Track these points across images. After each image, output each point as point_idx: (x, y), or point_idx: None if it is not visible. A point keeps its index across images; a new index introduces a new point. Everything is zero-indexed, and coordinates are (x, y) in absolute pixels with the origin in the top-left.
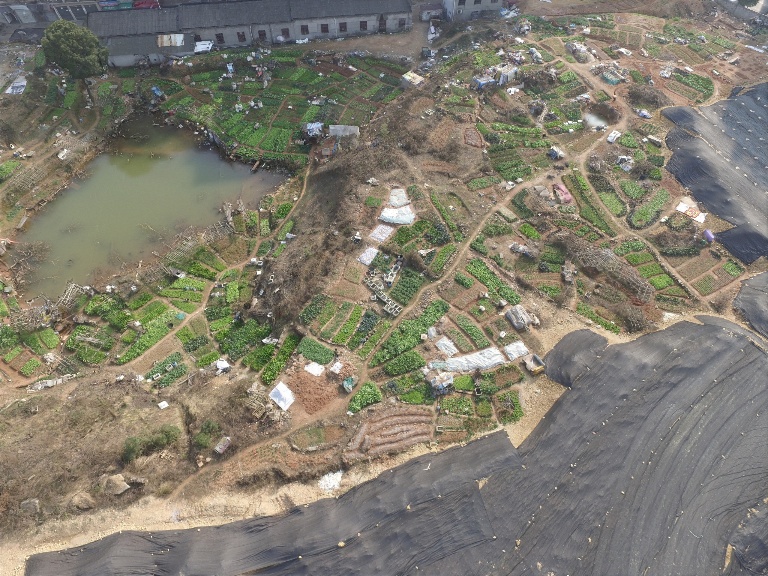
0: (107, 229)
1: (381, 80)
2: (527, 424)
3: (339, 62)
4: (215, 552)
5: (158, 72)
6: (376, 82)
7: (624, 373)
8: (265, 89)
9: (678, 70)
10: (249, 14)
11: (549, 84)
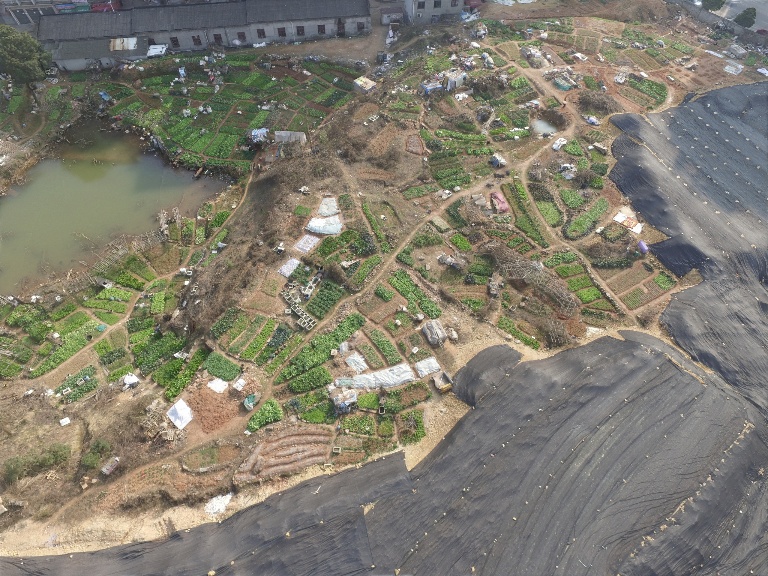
0: (40, 237)
1: (334, 85)
2: (427, 445)
3: (294, 66)
4: None
5: (108, 76)
6: (329, 87)
7: (531, 392)
8: (216, 94)
9: (633, 76)
10: (204, 17)
11: (500, 90)
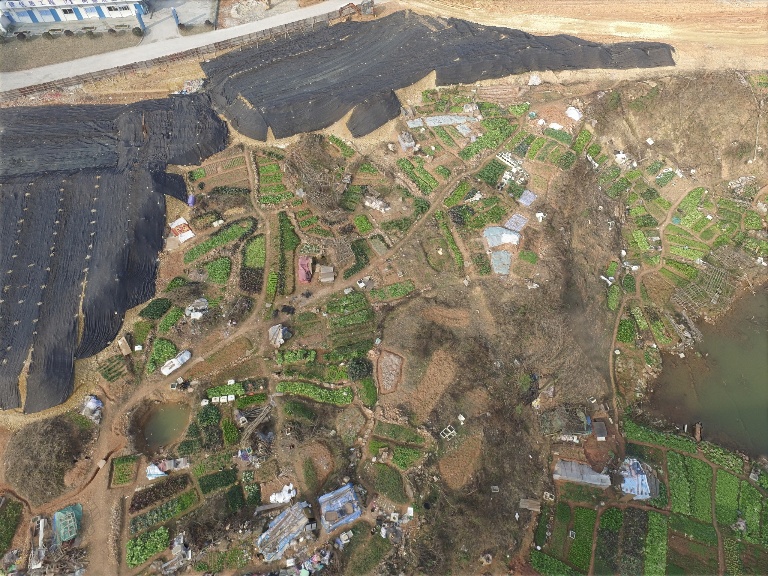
0: None
1: None
2: (422, 85)
3: None
4: (587, 56)
5: None
6: None
7: (354, 92)
8: None
9: None
10: None
11: None
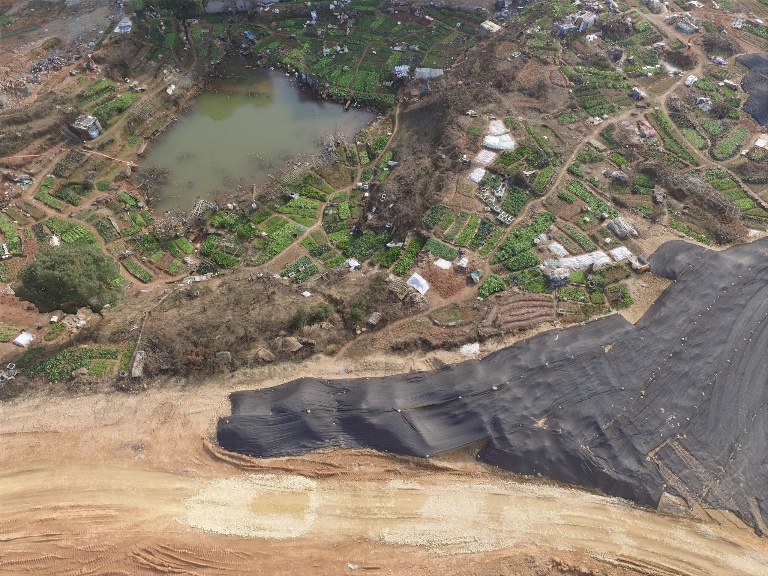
0: (219, 157)
1: (458, 29)
2: (638, 309)
3: (416, 12)
4: (387, 393)
5: (247, 18)
6: (453, 31)
7: (723, 270)
8: (348, 36)
9: (749, 22)
10: None
11: (625, 32)
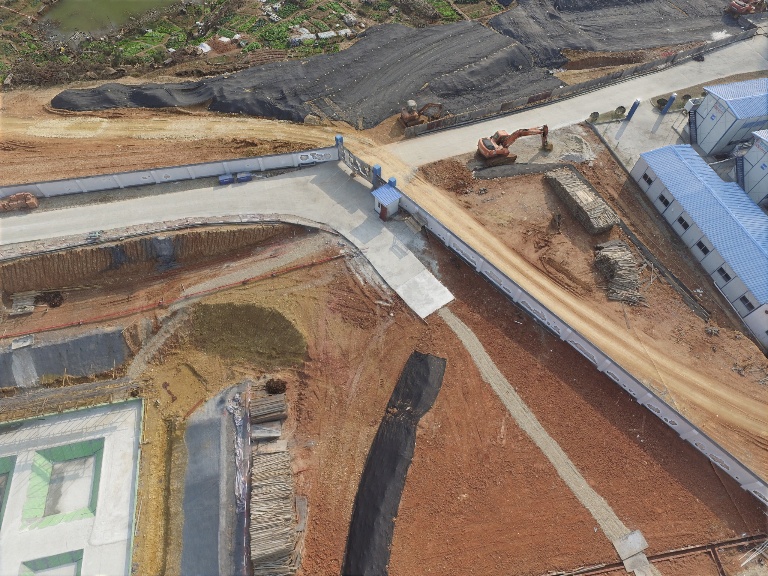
0: (100, 14)
1: None
2: None
3: None
4: None
5: None
6: None
7: (398, 31)
8: None
9: None
10: None
11: None
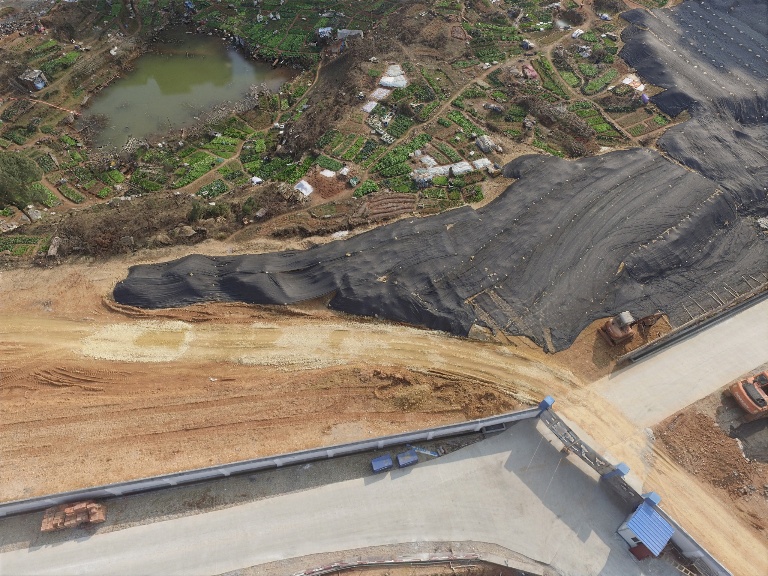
0: (154, 107)
1: None
2: (486, 202)
3: None
4: (260, 262)
5: None
6: None
7: (561, 170)
8: (282, 5)
9: None
10: None
11: None
